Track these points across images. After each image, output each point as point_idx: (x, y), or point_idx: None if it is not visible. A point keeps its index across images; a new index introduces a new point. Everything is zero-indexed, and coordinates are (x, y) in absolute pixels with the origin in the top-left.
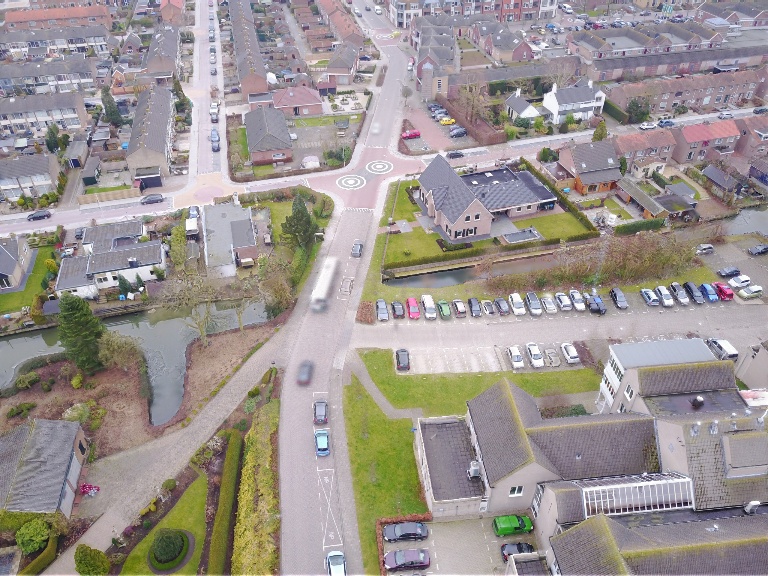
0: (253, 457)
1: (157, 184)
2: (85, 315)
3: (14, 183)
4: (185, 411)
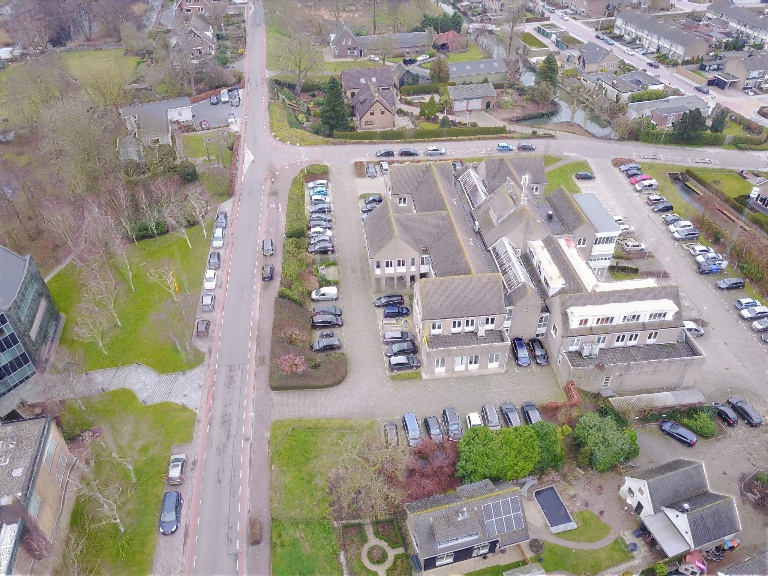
0: None
1: (723, 87)
2: (551, 70)
3: (670, 45)
4: None
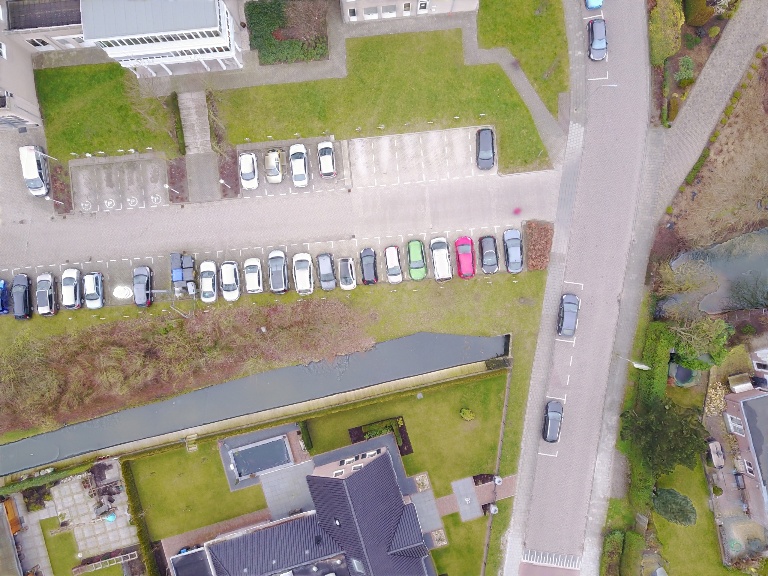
0: None
1: None
2: None
3: None
4: (766, 72)
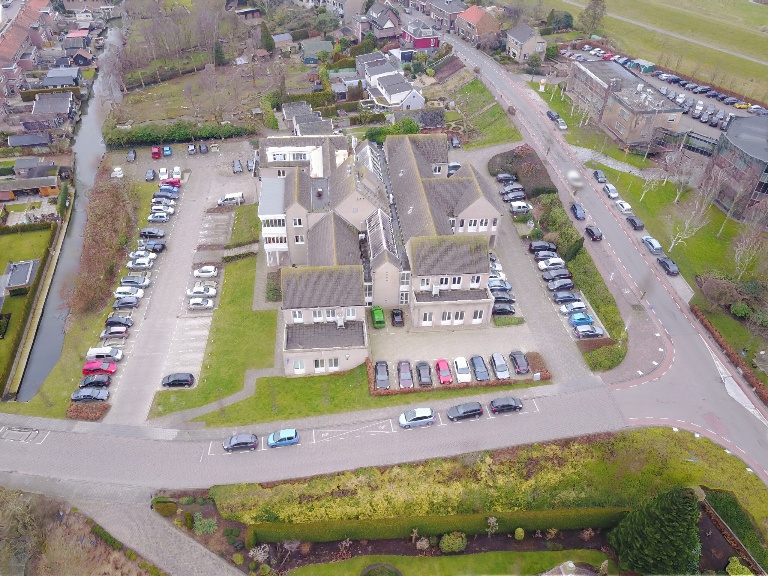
0: (288, 505)
1: None
2: None
3: None
4: None
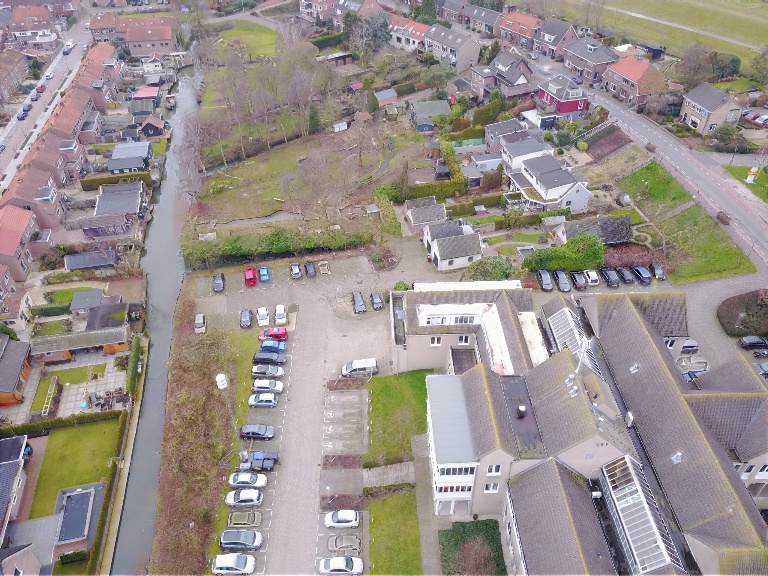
0: None
1: None
2: None
3: None
4: None
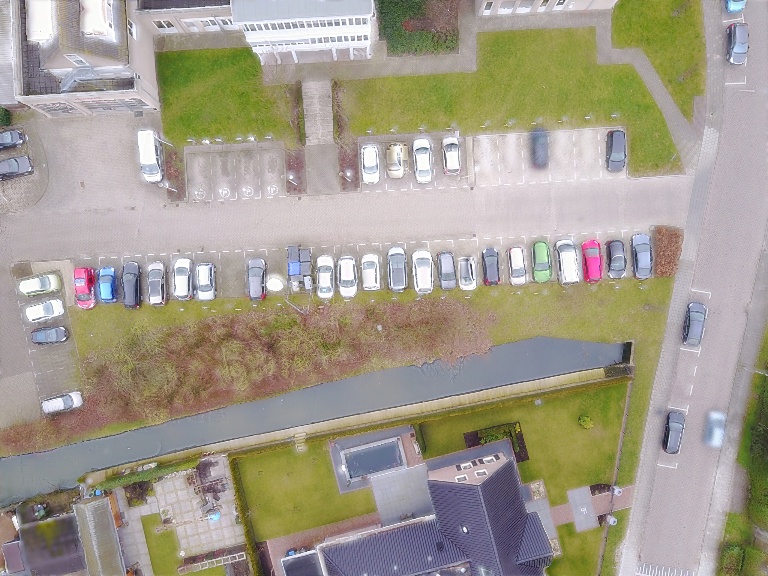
0: None
1: None
2: None
3: None
4: None
